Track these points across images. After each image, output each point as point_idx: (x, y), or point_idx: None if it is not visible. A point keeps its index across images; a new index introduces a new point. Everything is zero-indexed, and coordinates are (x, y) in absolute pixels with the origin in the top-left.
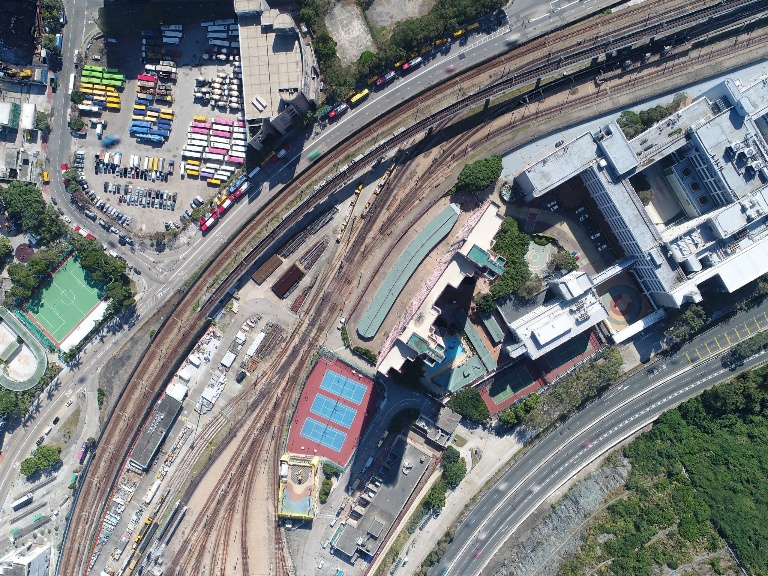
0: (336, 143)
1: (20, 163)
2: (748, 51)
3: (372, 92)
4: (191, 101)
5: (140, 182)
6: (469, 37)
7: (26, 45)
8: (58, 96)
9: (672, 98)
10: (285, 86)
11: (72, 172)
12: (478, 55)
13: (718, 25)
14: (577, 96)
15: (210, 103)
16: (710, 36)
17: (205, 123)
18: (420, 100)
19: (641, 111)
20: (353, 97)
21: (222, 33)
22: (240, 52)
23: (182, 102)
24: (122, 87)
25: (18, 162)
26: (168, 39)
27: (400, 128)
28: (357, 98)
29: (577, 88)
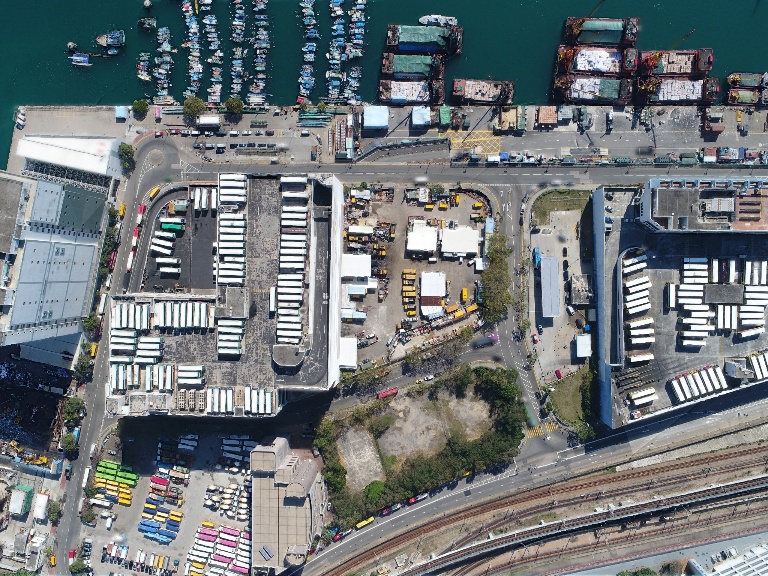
0: (339, 561)
1: (29, 553)
2: (746, 521)
3: (378, 516)
4: (201, 504)
5: (144, 575)
6: (476, 476)
7: (45, 434)
8: (72, 484)
9: (669, 557)
10: (293, 538)
11: (79, 565)
12: (483, 493)
13: (718, 498)
14: (576, 544)
15: (219, 508)
16: (710, 507)
17: (213, 530)
18: (424, 530)
19: (637, 572)
20: (359, 523)
21: (236, 446)
22: (252, 503)
23: (192, 504)
24: (135, 484)
25: (27, 546)
26: (183, 446)
27: (402, 555)
28: (362, 525)
29: (577, 537)
